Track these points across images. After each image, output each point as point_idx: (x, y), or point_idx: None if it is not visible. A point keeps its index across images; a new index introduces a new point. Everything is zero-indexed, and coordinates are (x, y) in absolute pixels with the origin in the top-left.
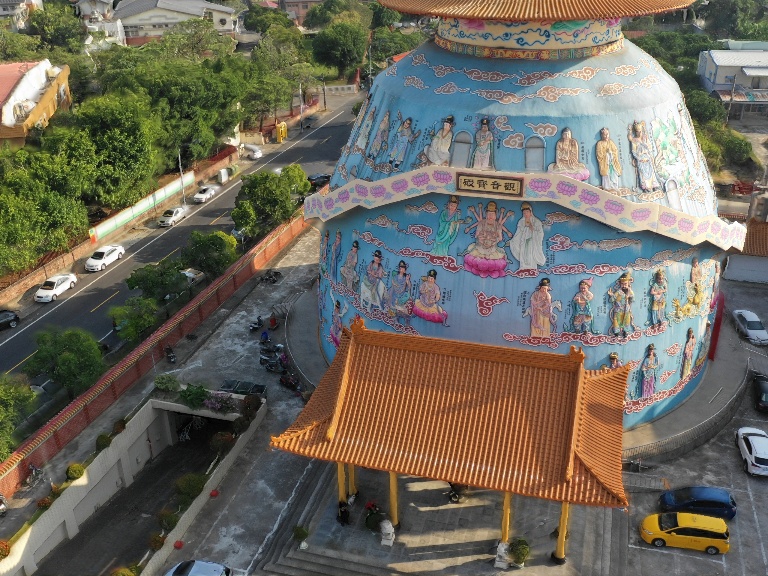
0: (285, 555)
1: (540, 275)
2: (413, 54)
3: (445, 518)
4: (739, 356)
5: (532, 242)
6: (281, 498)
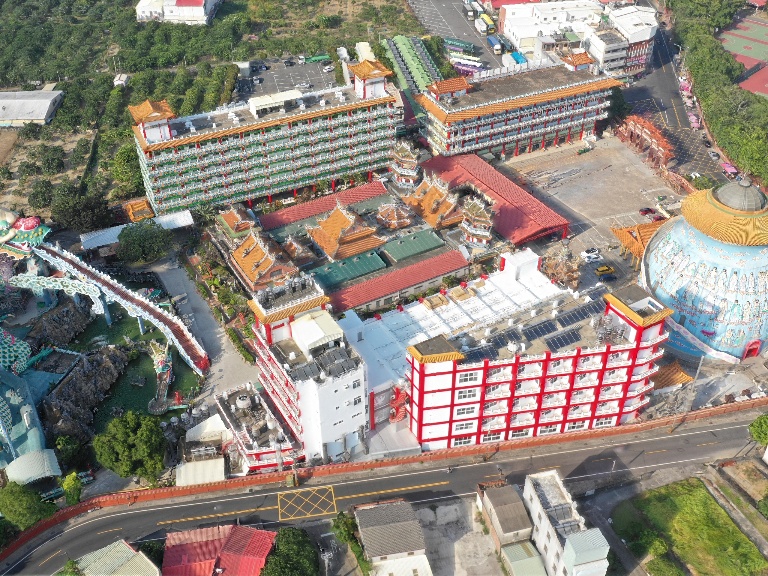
0: None
1: None
2: None
3: None
4: None
5: None
6: None
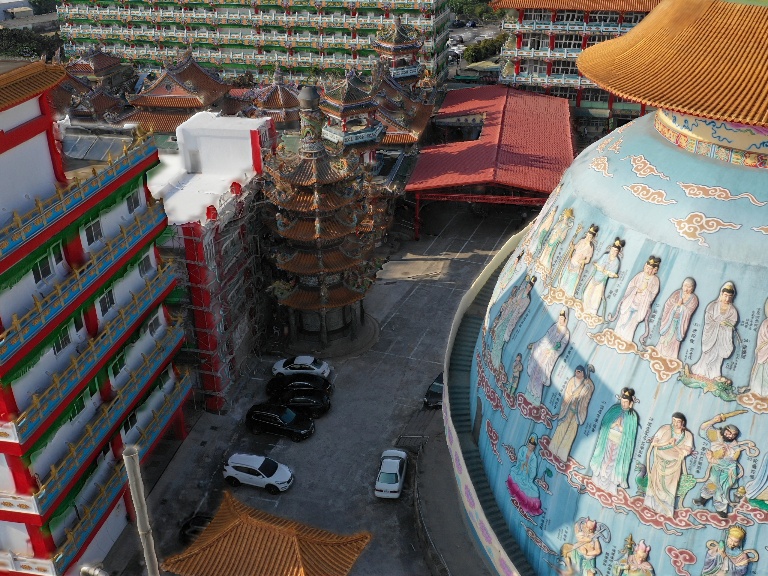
0: None
1: None
2: None
3: None
4: (442, 425)
5: None
6: None
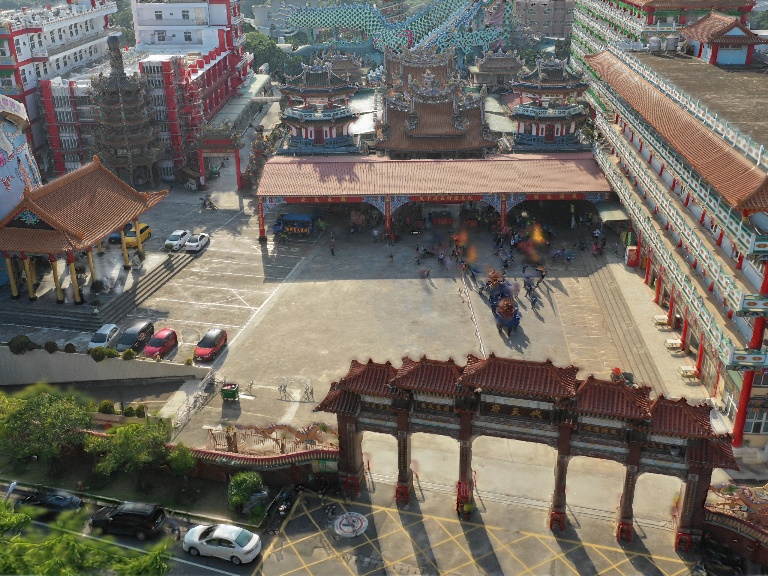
0: (99, 319)
1: (15, 156)
2: None
3: (97, 279)
4: None
5: (4, 139)
6: (39, 330)
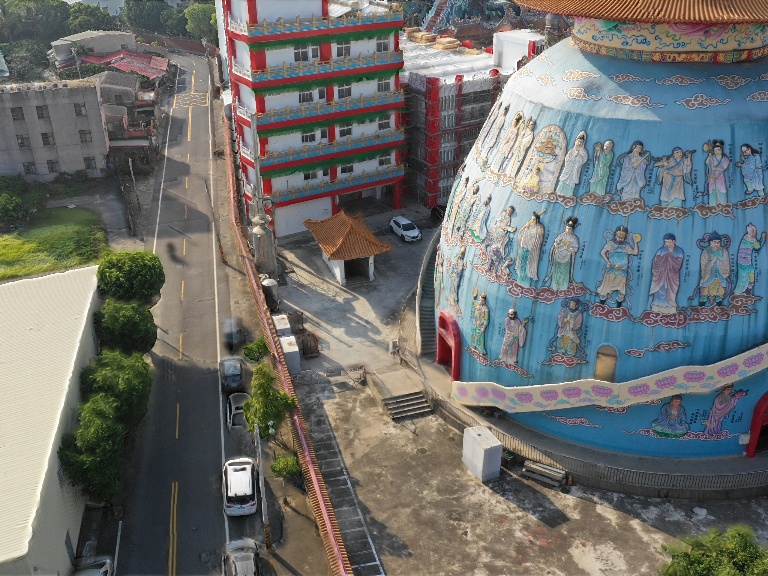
0: None
1: None
2: None
3: None
4: None
5: None
6: None
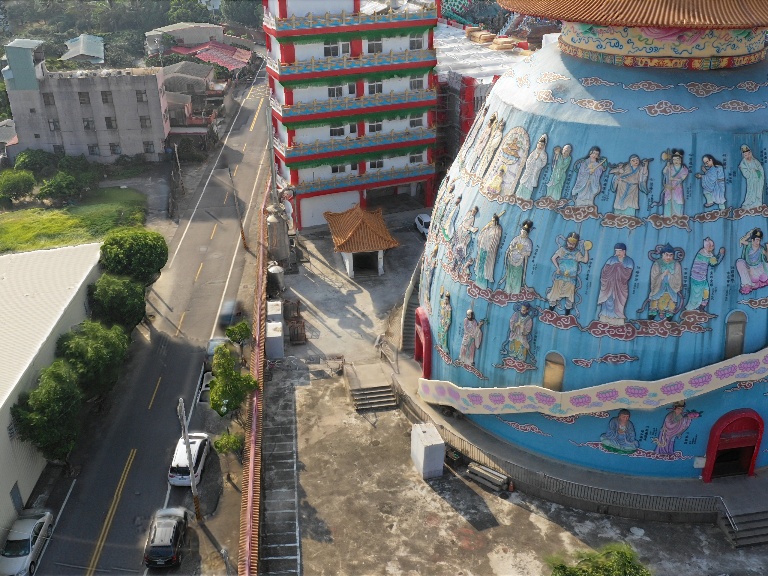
0: None
1: None
2: (765, 82)
3: None
4: None
5: None
6: None
